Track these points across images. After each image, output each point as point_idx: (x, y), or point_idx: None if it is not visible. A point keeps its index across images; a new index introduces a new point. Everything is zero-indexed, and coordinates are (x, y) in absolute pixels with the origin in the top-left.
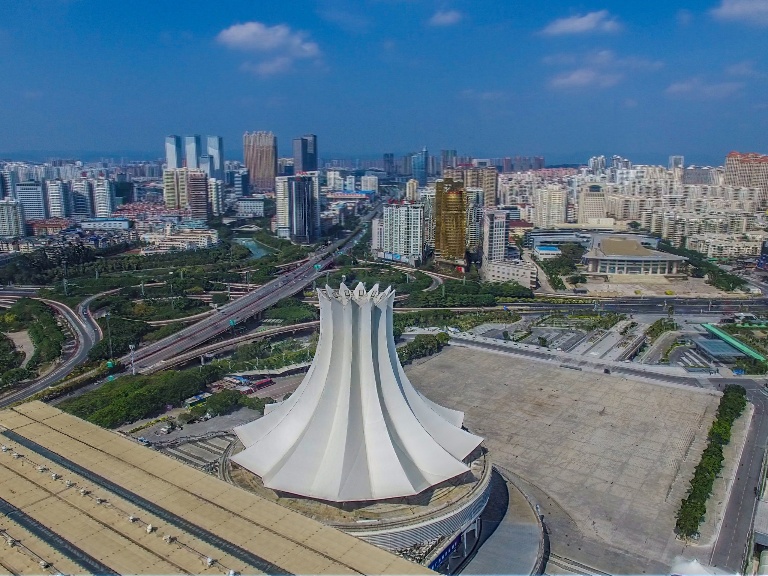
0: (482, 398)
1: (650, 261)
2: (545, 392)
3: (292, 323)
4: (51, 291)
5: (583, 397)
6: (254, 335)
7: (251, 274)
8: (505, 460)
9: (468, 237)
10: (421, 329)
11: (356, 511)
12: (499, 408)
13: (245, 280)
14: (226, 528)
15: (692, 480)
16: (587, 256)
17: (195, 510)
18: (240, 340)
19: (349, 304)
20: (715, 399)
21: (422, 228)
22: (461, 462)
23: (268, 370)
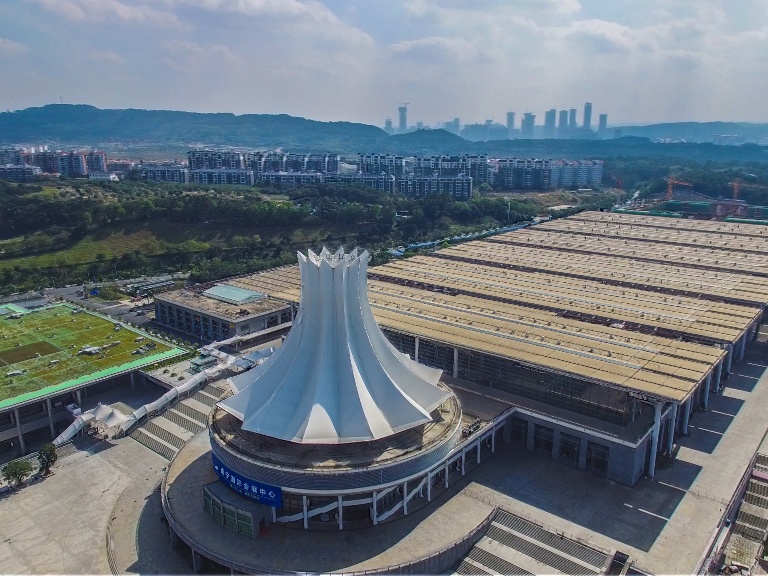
0: None
1: None
2: None
3: None
4: None
5: None
6: None
7: None
8: None
9: None
10: None
11: None
12: None
13: None
14: None
15: None
16: None
17: None
18: None
19: None
20: None
21: None
22: None
23: None
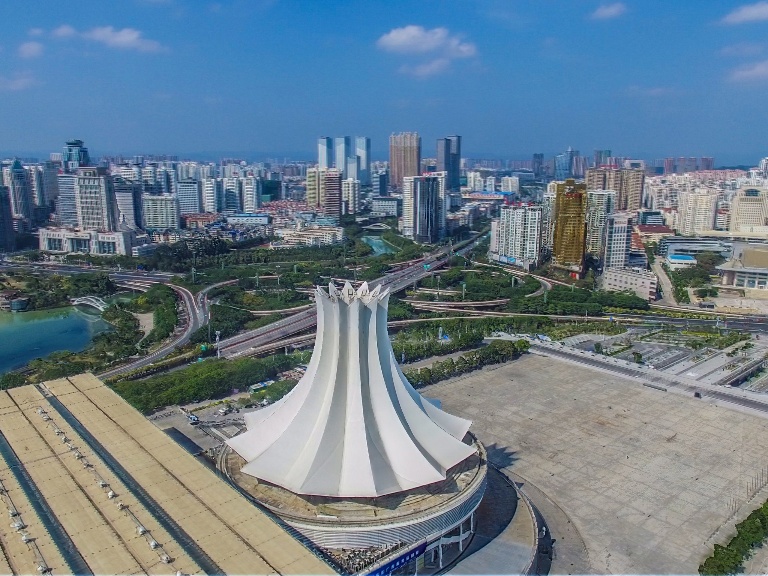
0: (541, 411)
1: None
2: (614, 411)
3: None
4: (181, 278)
5: (656, 420)
6: None
7: (363, 271)
8: (538, 477)
9: (589, 242)
10: (508, 335)
11: (318, 505)
12: (555, 423)
13: None
14: (175, 503)
15: (738, 524)
16: (721, 267)
17: (159, 484)
18: None
19: (337, 302)
20: None
21: (539, 231)
22: (438, 470)
23: None
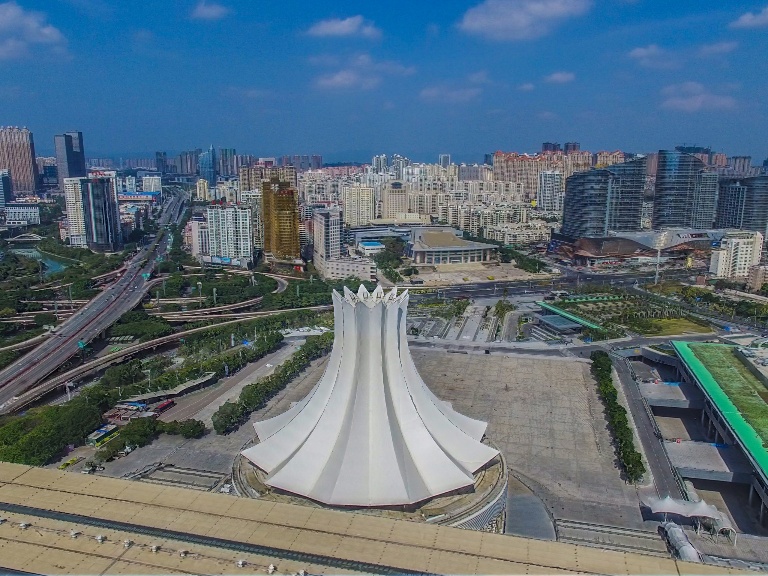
0: None
1: (468, 250)
2: (450, 377)
3: (150, 338)
4: None
5: (484, 377)
6: (112, 356)
7: (65, 289)
8: None
9: None
10: (296, 331)
11: (423, 510)
12: None
13: (58, 296)
14: (347, 550)
15: (618, 434)
16: (415, 249)
17: (298, 540)
18: (99, 363)
19: (379, 307)
20: (584, 365)
21: (251, 229)
22: (490, 447)
23: (163, 391)
